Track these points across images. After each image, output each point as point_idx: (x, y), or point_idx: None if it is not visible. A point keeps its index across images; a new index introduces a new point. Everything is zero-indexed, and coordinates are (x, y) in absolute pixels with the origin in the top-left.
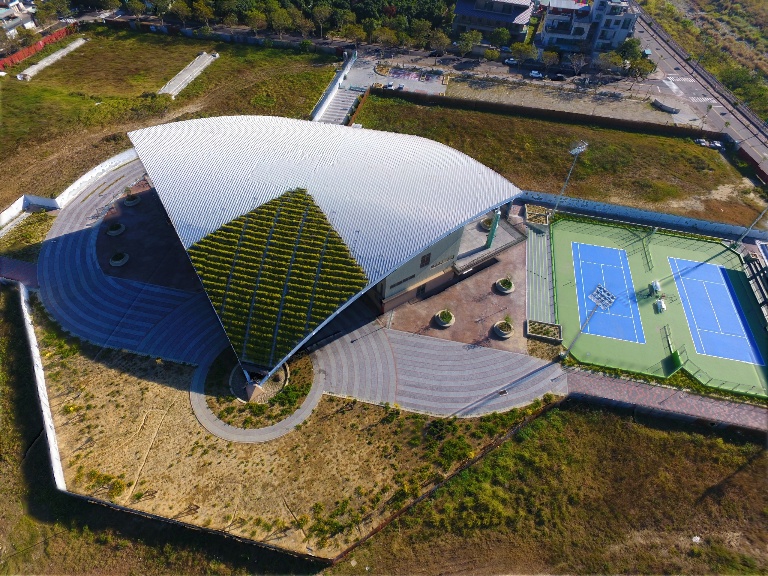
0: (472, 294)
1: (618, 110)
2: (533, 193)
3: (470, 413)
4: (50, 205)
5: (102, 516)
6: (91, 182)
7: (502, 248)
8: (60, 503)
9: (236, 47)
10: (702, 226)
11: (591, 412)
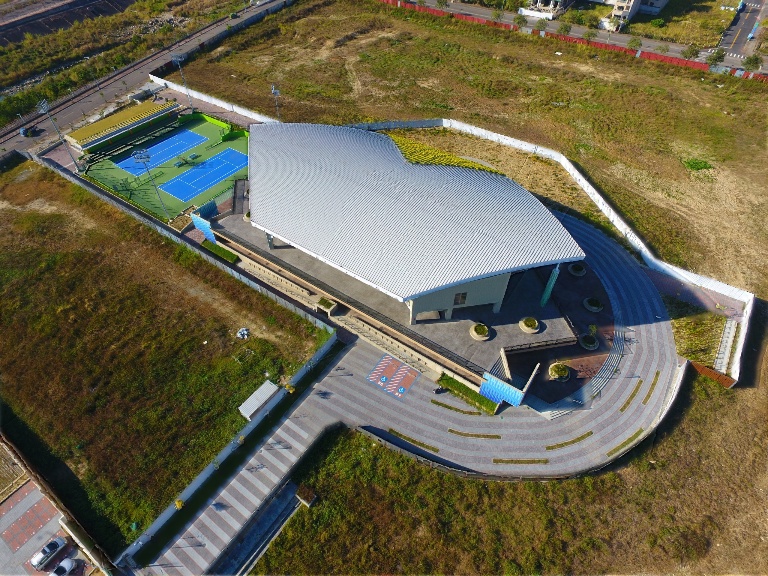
0: None
1: None
2: (164, 231)
3: None
4: None
5: None
6: None
7: None
8: None
9: None
10: None
11: None
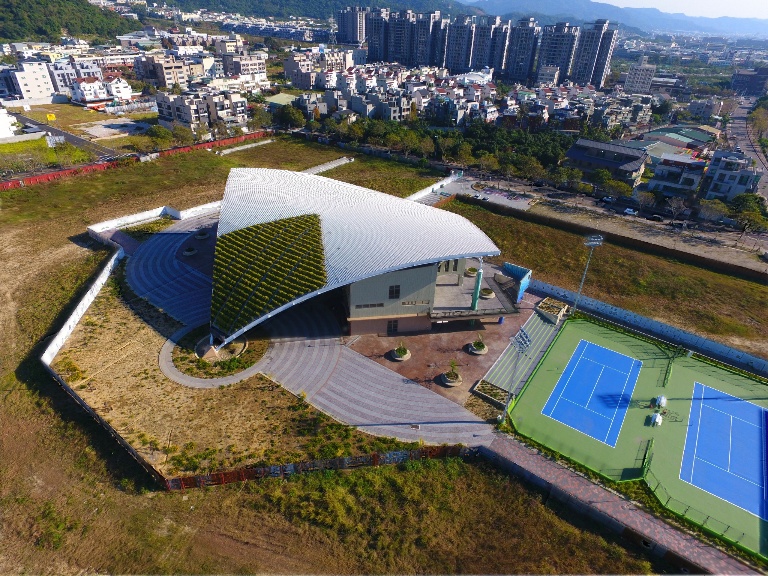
0: (441, 345)
1: (712, 253)
2: (558, 289)
3: (371, 430)
4: (177, 216)
5: (52, 389)
6: (211, 210)
7: (486, 313)
8: (37, 371)
9: (370, 157)
10: (760, 366)
11: (496, 475)
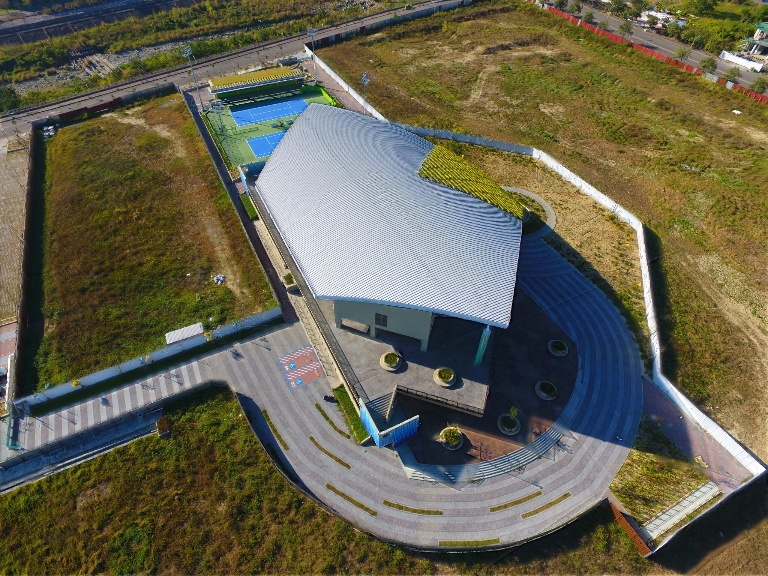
0: None
1: None
2: None
3: None
4: None
5: None
6: (543, 536)
7: None
8: None
9: None
10: None
11: None
